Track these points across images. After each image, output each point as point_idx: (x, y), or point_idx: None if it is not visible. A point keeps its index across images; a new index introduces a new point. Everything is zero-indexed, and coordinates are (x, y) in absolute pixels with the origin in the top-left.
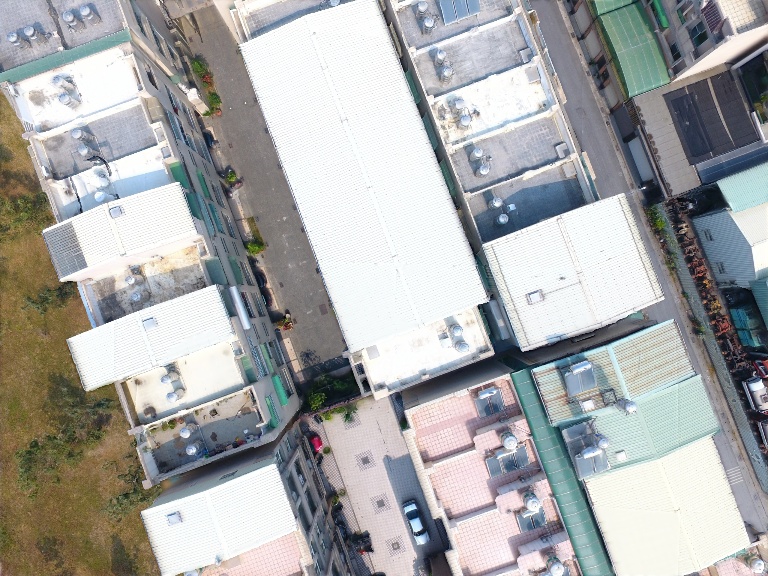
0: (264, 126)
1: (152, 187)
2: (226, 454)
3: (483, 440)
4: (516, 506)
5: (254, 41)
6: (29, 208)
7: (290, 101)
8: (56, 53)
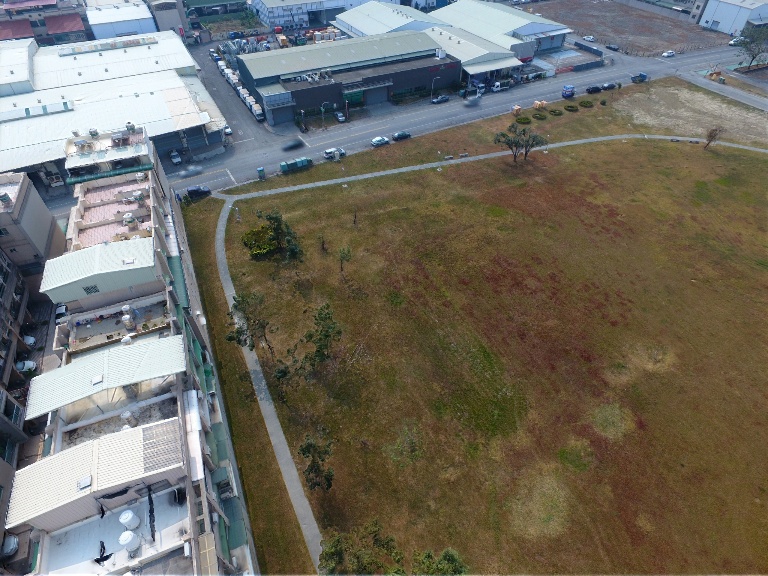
0: None
1: (81, 545)
2: (104, 309)
3: None
4: None
5: None
6: (325, 560)
7: None
8: None
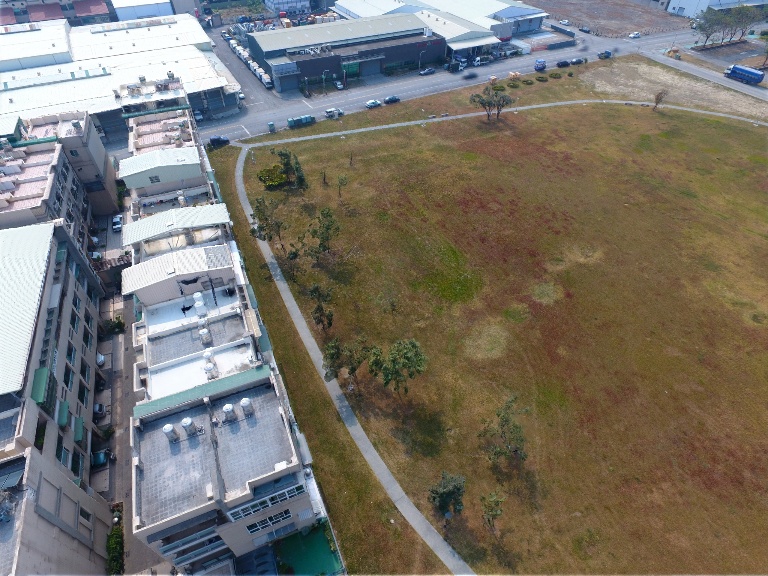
0: (128, 468)
1: (167, 314)
2: (163, 195)
3: (2, 197)
4: (5, 178)
5: (4, 391)
6: (327, 350)
7: (1, 346)
8: (211, 395)
